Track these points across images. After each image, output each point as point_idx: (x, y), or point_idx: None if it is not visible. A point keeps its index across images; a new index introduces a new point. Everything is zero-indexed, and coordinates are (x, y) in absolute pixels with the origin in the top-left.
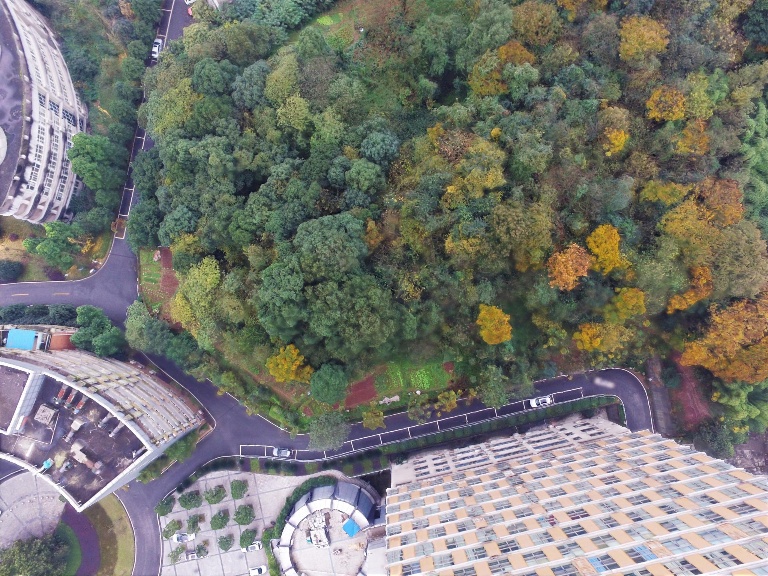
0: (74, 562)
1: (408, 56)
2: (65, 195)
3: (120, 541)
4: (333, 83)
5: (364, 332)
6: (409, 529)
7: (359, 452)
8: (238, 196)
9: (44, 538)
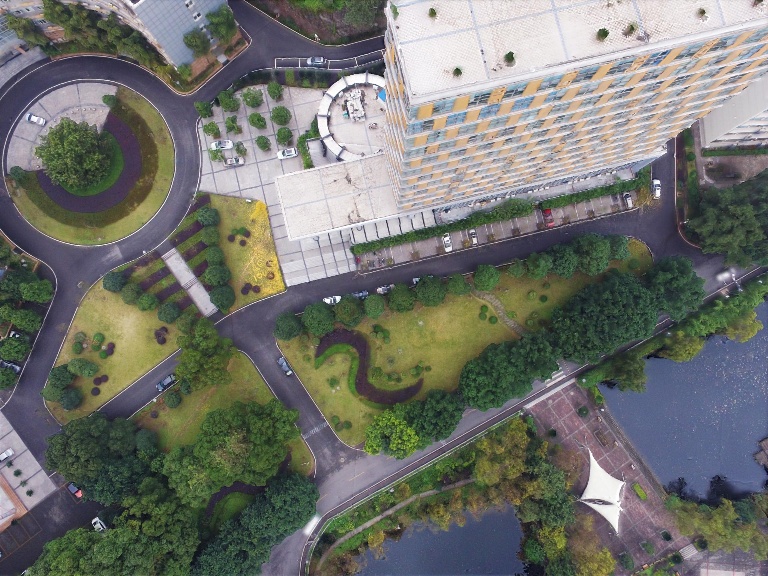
0: (117, 167)
1: None
2: None
3: (160, 151)
4: None
5: None
6: None
7: None
8: None
9: None
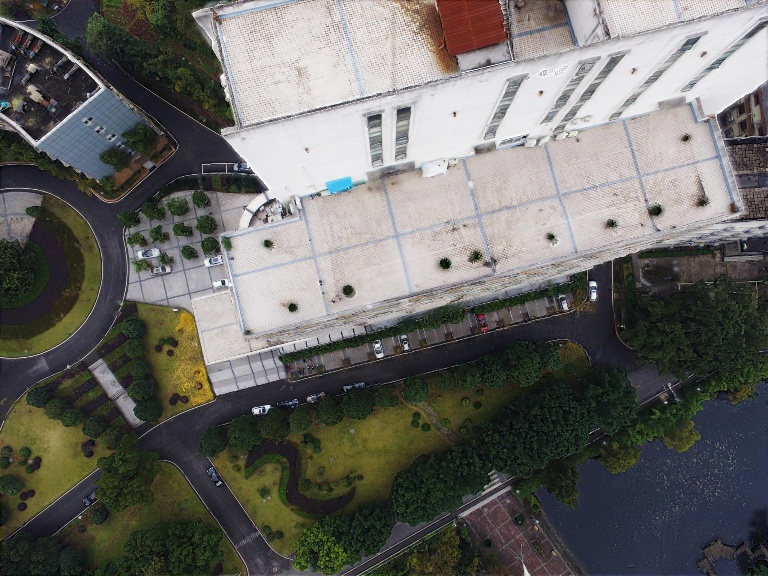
0: (42, 278)
1: None
2: None
3: (87, 260)
4: None
5: None
6: None
7: None
8: None
9: (11, 242)
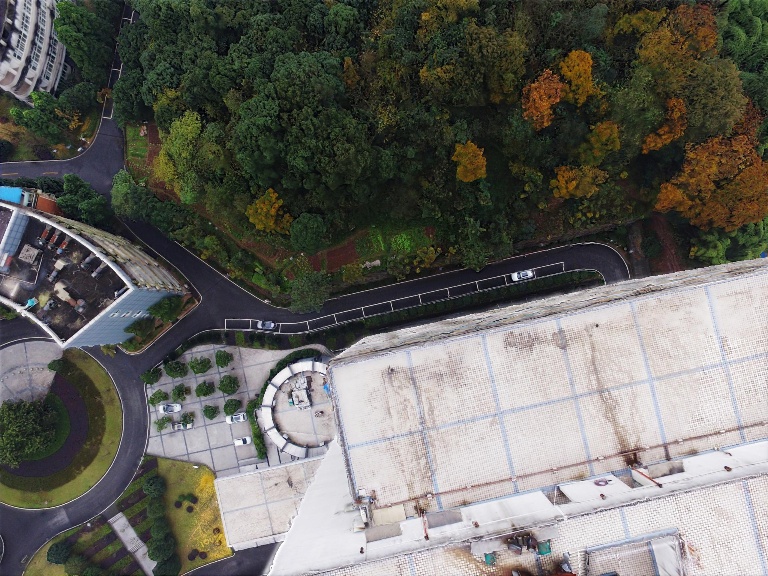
0: (63, 431)
1: None
2: (53, 76)
3: (108, 412)
4: None
5: (339, 159)
6: None
7: (342, 324)
8: (220, 56)
9: (33, 402)
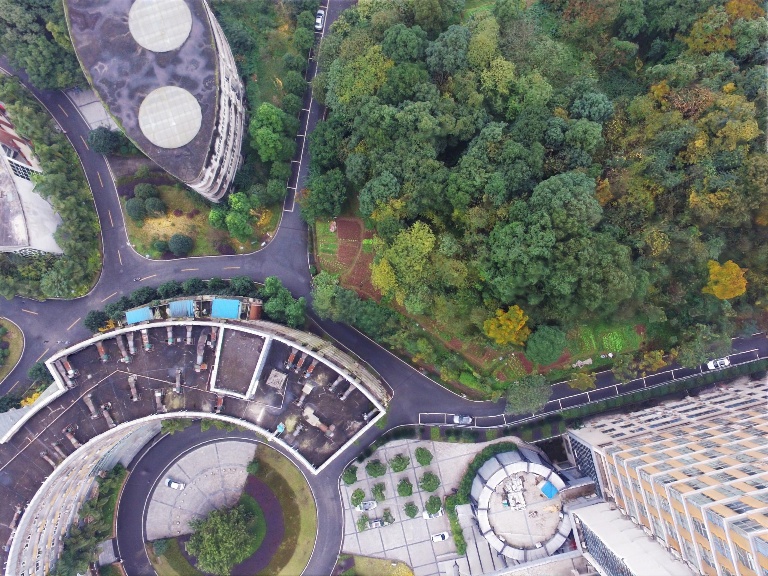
0: (259, 533)
1: (597, 19)
2: (232, 169)
3: (302, 511)
4: (538, 45)
5: (613, 287)
6: (685, 476)
7: (540, 417)
8: None
9: (237, 508)
